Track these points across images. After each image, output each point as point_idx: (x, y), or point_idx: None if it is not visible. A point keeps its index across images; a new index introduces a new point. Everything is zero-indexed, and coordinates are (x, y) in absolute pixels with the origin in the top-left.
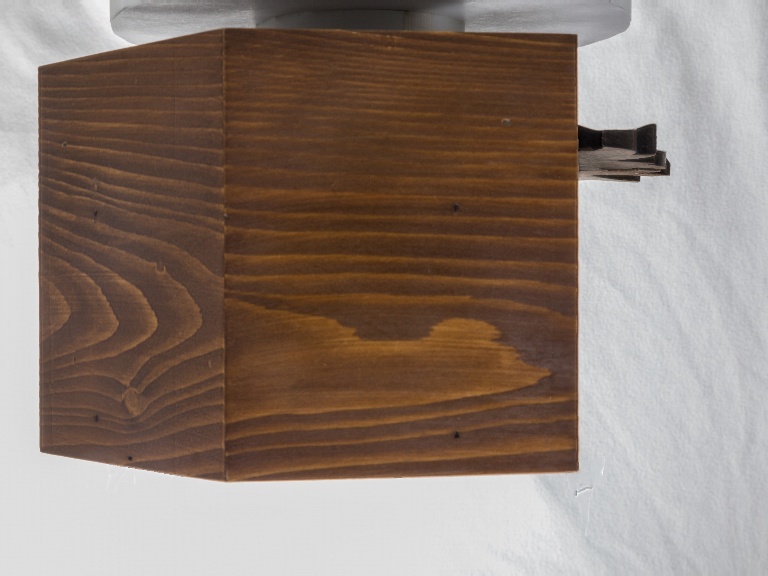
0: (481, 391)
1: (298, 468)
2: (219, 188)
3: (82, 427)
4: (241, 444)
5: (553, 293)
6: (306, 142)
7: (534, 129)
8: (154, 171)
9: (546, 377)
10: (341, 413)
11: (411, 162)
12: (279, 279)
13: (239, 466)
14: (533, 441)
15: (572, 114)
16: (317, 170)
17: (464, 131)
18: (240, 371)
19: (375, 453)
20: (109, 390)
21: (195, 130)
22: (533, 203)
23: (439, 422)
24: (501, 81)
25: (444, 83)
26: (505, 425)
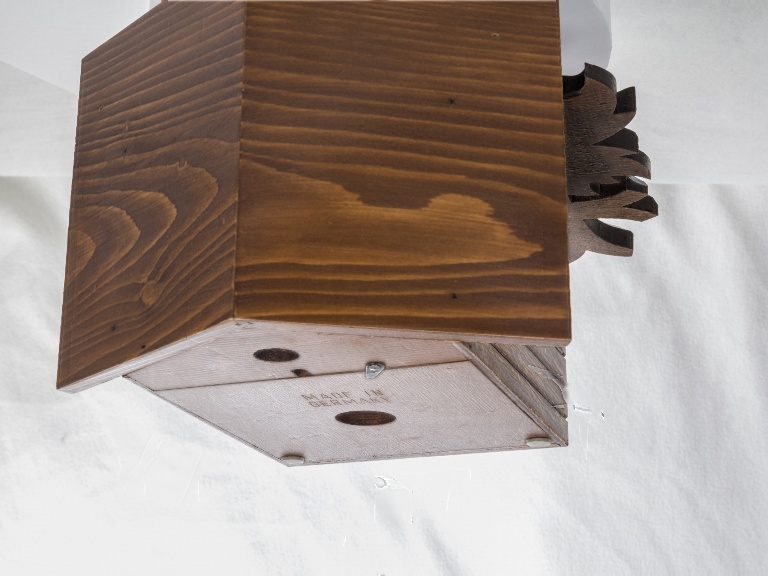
0: (477, 259)
1: (303, 312)
2: (238, 70)
3: (99, 343)
4: (250, 286)
5: (542, 180)
6: (317, 37)
7: (521, 44)
8: (181, 87)
9: (538, 252)
10: (345, 267)
11: (411, 61)
12: (290, 147)
13: (247, 305)
14: (527, 308)
15: (555, 34)
16: (327, 60)
17: (458, 40)
18: (251, 222)
19: (376, 305)
20: (127, 295)
21: (219, 35)
22: (522, 103)
23: (437, 283)
24: (491, 3)
25: (440, 1)
26: (500, 291)
